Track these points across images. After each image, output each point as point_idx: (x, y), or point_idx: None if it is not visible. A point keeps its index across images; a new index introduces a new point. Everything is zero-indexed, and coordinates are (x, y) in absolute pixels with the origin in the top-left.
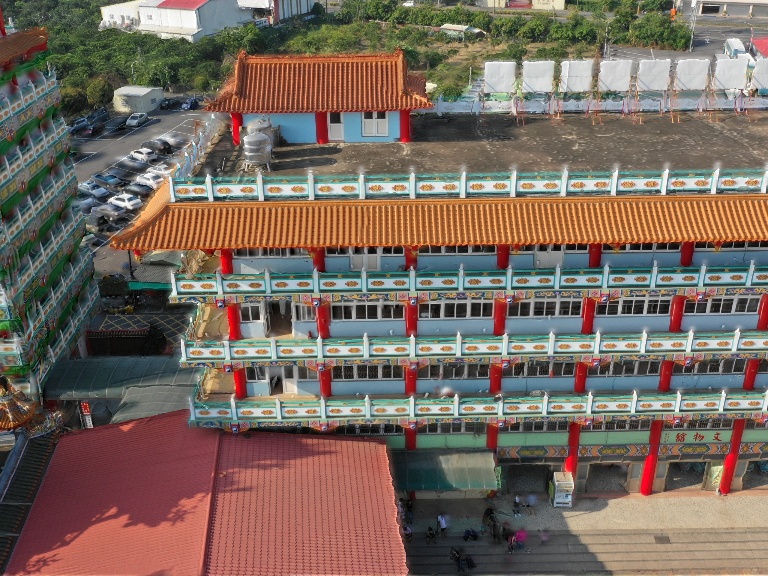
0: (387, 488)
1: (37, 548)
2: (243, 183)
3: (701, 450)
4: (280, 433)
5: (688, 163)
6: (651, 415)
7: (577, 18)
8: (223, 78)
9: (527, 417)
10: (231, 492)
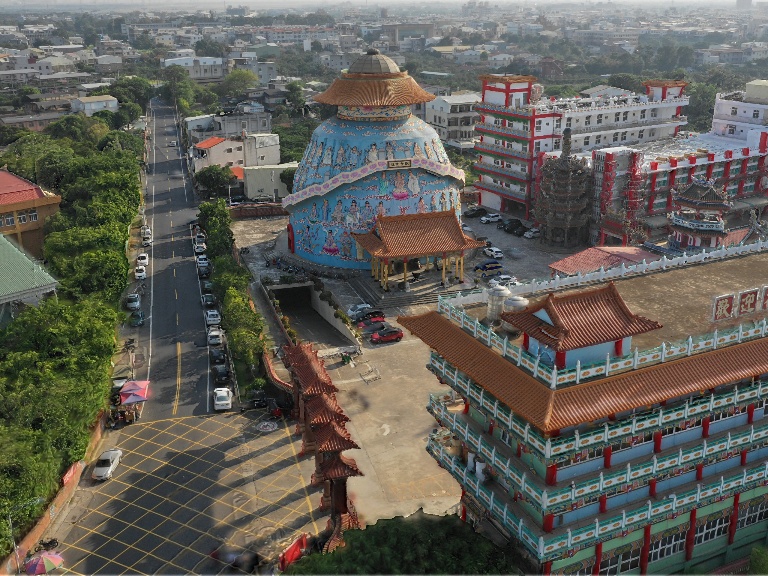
0: None
1: None
2: None
3: None
4: None
5: (760, 272)
6: None
7: None
8: None
9: None
10: None
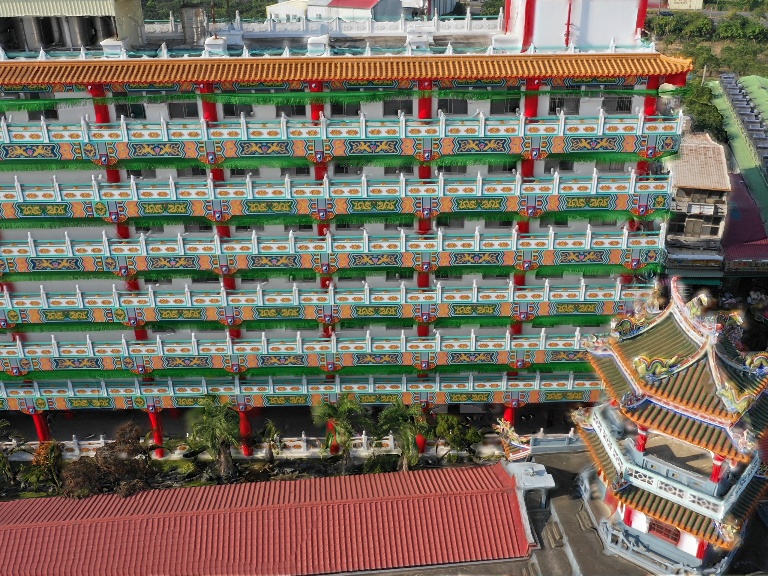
0: None
1: None
2: None
3: None
4: None
5: None
6: None
7: (735, 17)
8: None
9: None
10: None
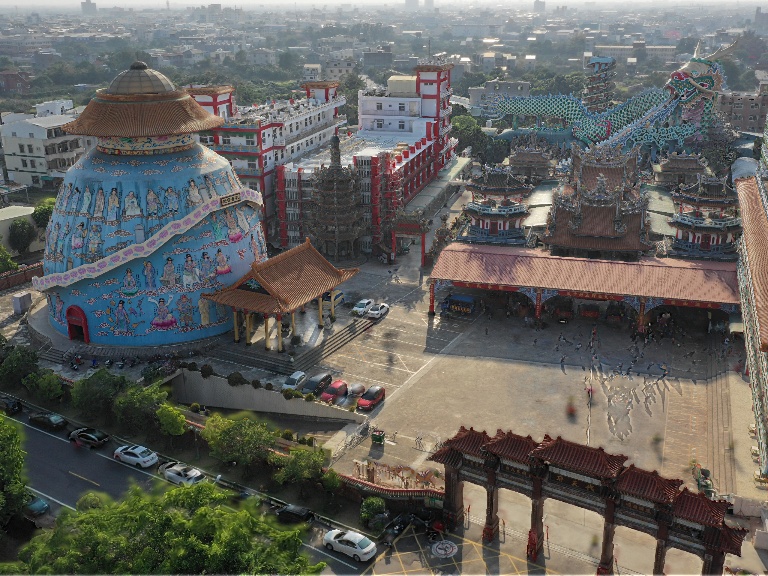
0: None
1: None
2: None
3: None
4: None
5: None
6: None
7: None
8: None
9: None
10: None
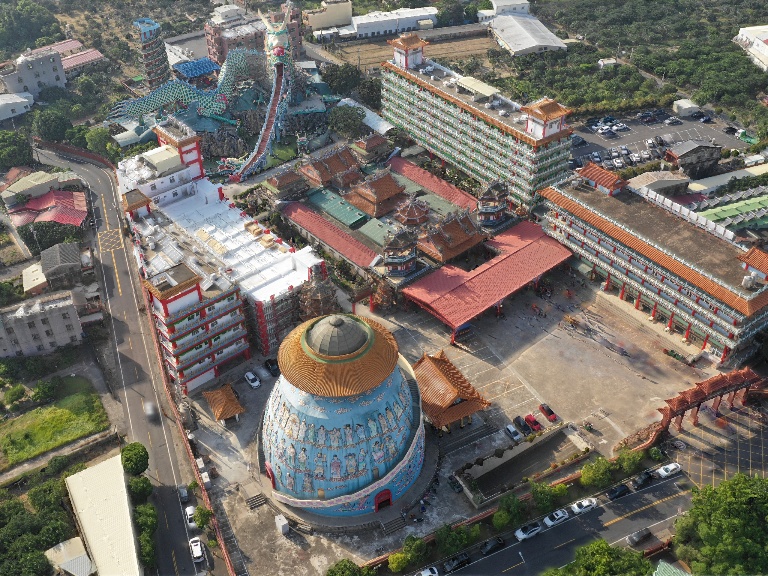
0: (563, 259)
1: (506, 234)
2: (566, 190)
3: (632, 294)
4: (557, 241)
5: (646, 228)
6: (615, 275)
7: None
8: (745, 106)
9: (594, 262)
10: (537, 243)
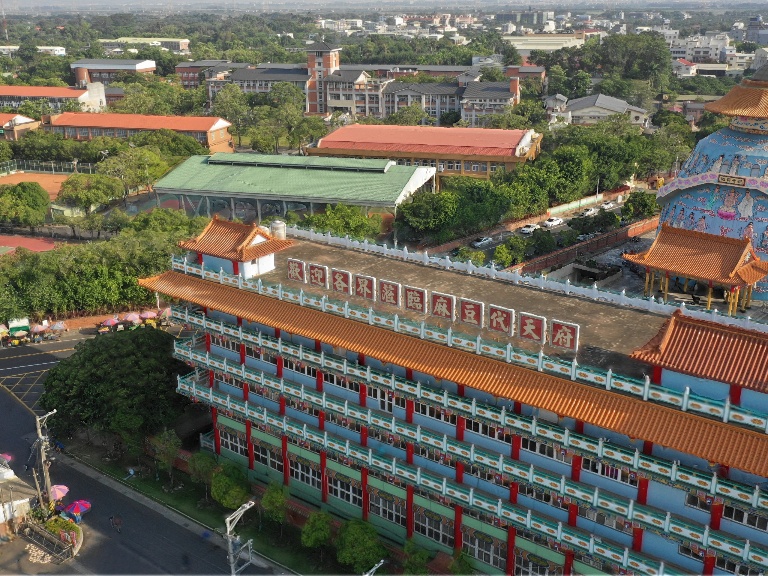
0: None
1: None
2: None
3: None
4: None
5: (513, 303)
6: None
7: None
8: None
9: None
10: None
